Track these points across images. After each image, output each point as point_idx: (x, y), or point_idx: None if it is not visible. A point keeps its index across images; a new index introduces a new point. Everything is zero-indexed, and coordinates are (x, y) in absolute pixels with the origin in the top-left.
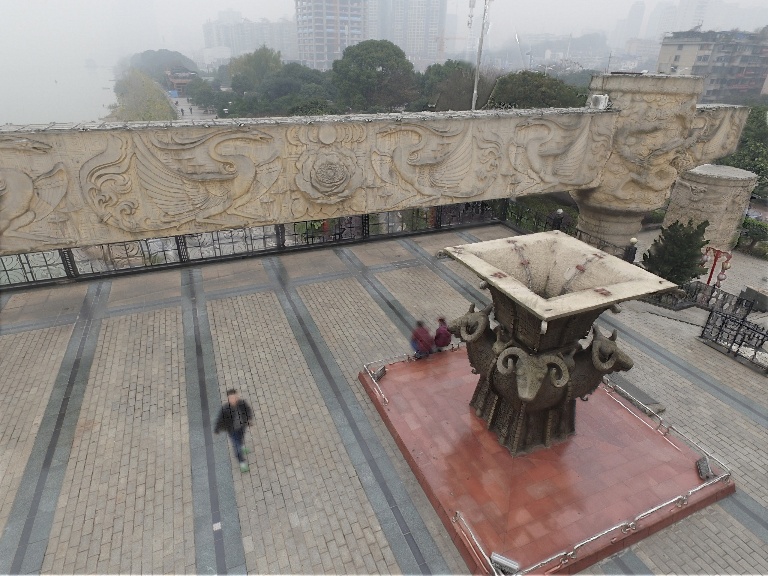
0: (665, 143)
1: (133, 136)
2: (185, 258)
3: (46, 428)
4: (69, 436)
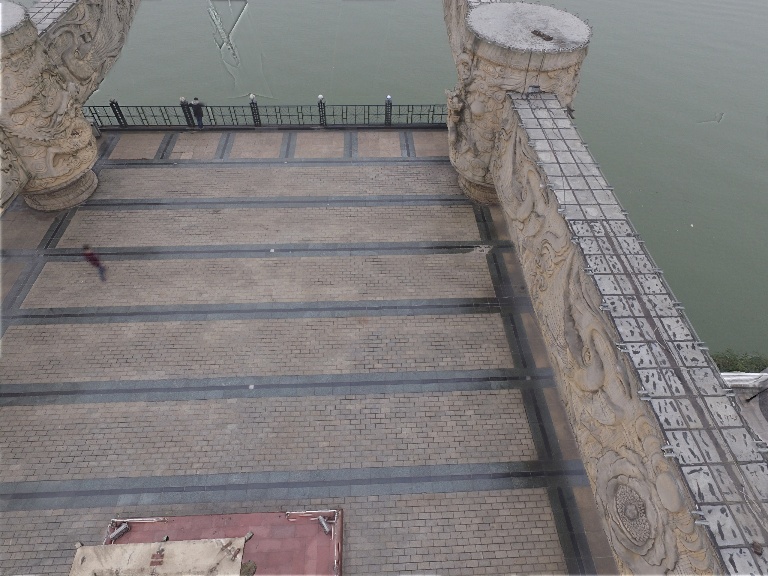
0: None
1: None
2: None
3: (370, 303)
4: (358, 315)
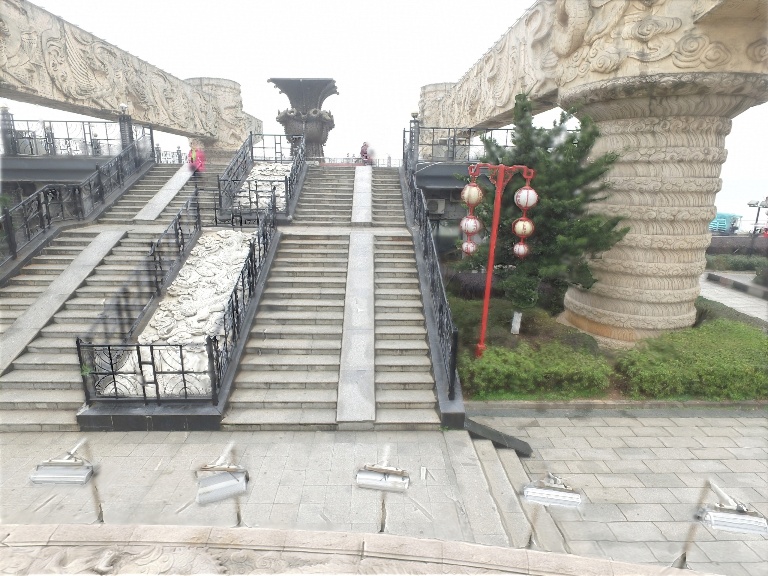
0: None
1: None
2: None
3: None
4: None
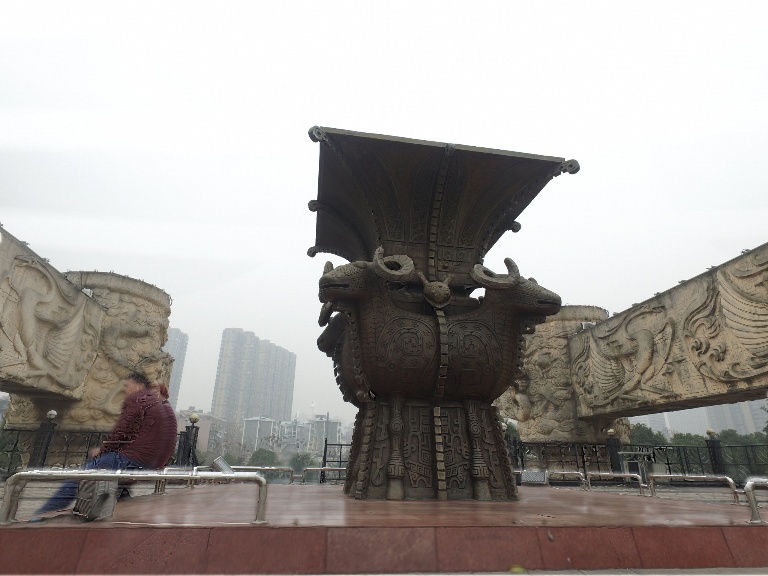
0: (152, 353)
1: None
2: None
3: None
4: None
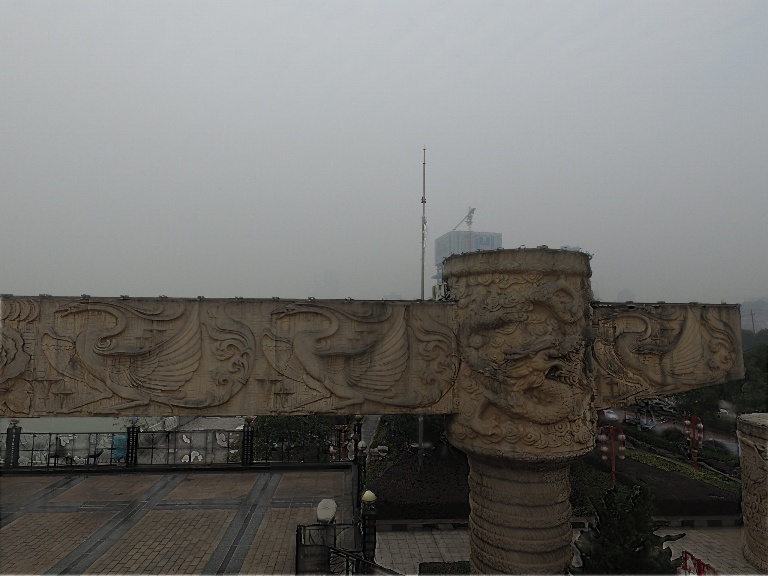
0: (529, 343)
1: None
2: None
3: None
4: None
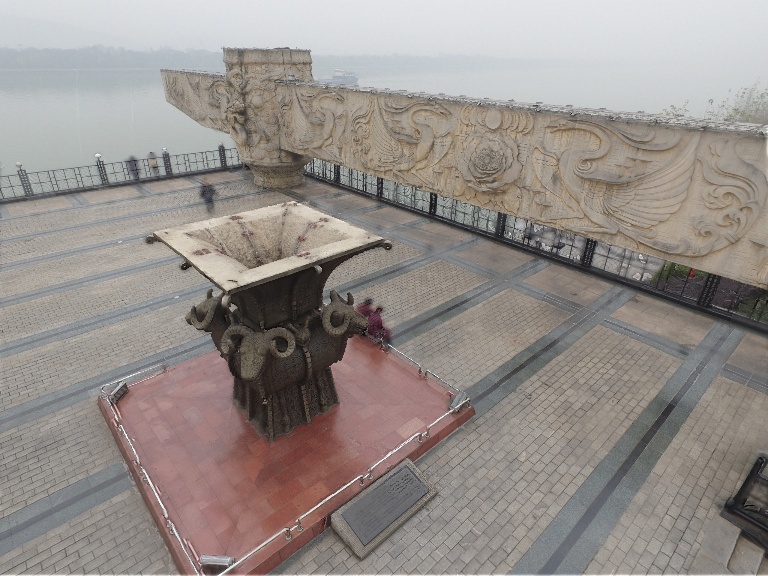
0: None
1: (375, 98)
2: (433, 211)
3: None
4: None
